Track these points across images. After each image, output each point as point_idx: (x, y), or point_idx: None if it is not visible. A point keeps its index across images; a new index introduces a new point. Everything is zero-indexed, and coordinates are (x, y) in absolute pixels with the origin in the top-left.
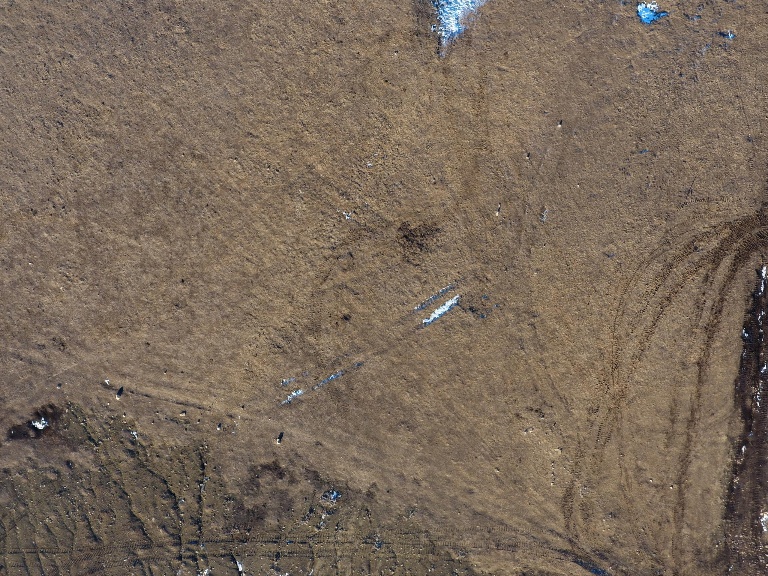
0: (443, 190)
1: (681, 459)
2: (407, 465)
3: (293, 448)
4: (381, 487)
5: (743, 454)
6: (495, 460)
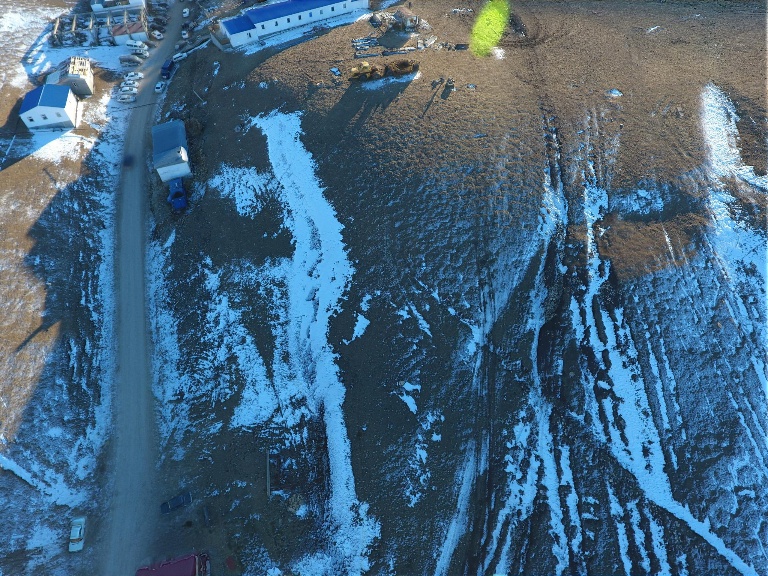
0: (678, 50)
1: (530, 8)
2: (638, 5)
3: (687, 7)
4: (644, 2)
5: (506, 9)
6: (603, 7)
